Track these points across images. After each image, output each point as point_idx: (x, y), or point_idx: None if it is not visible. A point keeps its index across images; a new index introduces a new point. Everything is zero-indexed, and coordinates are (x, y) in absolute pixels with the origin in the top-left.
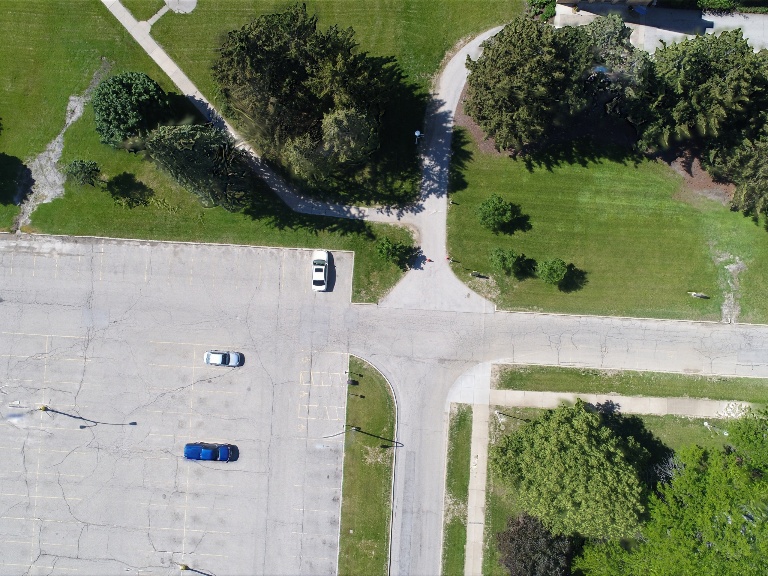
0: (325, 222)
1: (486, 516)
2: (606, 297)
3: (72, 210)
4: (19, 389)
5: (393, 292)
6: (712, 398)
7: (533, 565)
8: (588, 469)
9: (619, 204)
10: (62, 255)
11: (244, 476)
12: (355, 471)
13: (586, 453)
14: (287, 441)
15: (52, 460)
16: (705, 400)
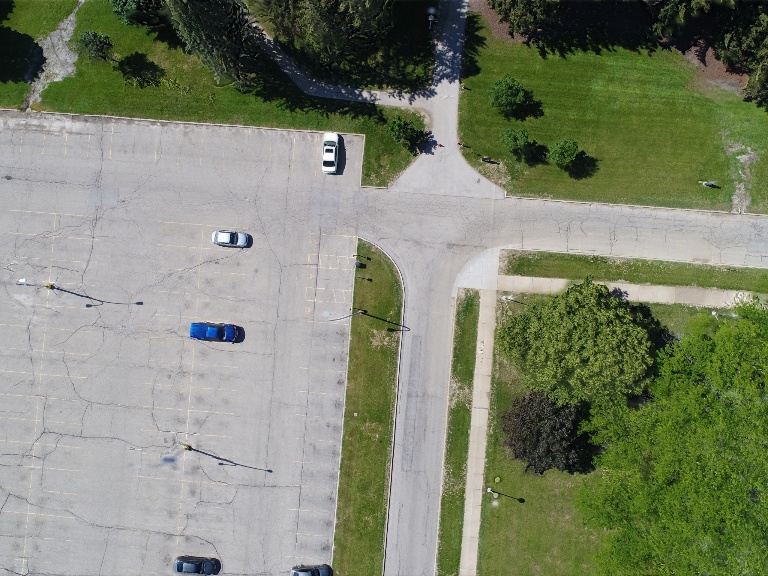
0: (336, 105)
1: (491, 401)
2: (617, 185)
3: (83, 89)
4: (26, 267)
5: (403, 176)
6: (720, 288)
7: (539, 429)
8: (597, 325)
9: (632, 92)
10: (72, 134)
11: (249, 358)
12: (361, 354)
13: (595, 314)
14: (293, 323)
15: (58, 338)
16: (713, 289)
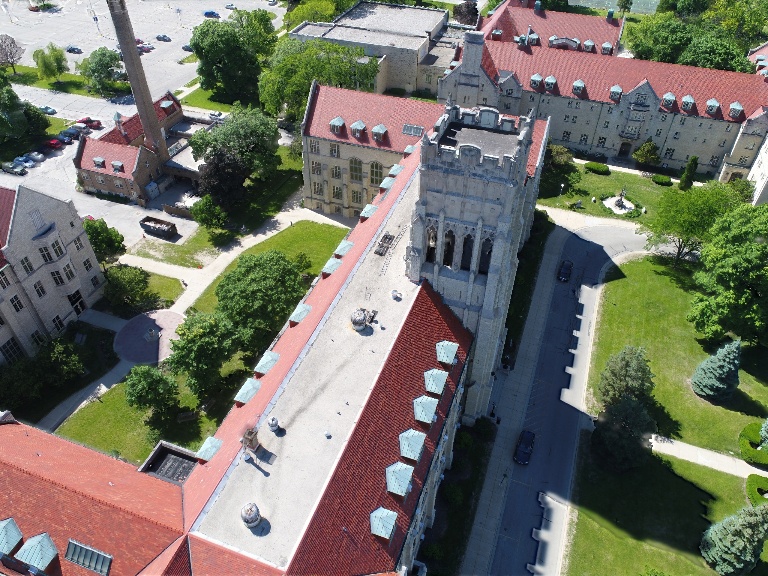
0: None
1: None
2: None
3: None
4: (166, 5)
5: None
6: None
7: None
8: None
9: None
10: None
11: None
12: None
13: None
14: None
15: None
16: None
